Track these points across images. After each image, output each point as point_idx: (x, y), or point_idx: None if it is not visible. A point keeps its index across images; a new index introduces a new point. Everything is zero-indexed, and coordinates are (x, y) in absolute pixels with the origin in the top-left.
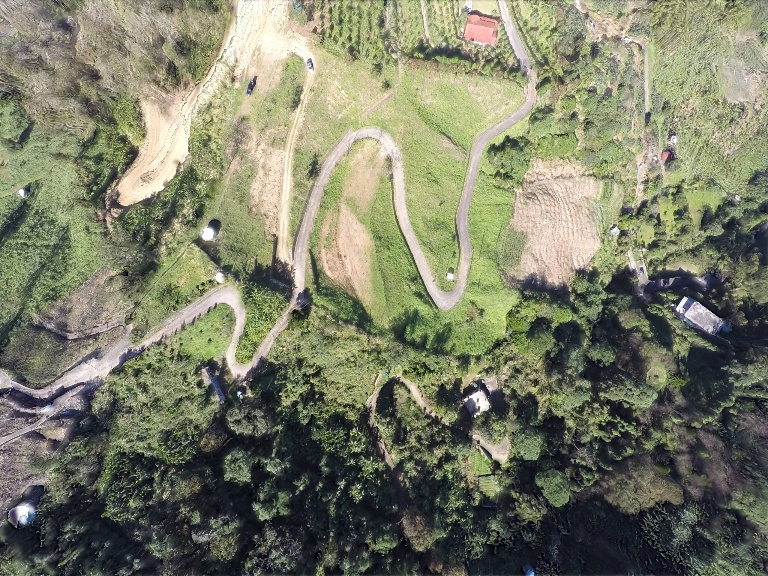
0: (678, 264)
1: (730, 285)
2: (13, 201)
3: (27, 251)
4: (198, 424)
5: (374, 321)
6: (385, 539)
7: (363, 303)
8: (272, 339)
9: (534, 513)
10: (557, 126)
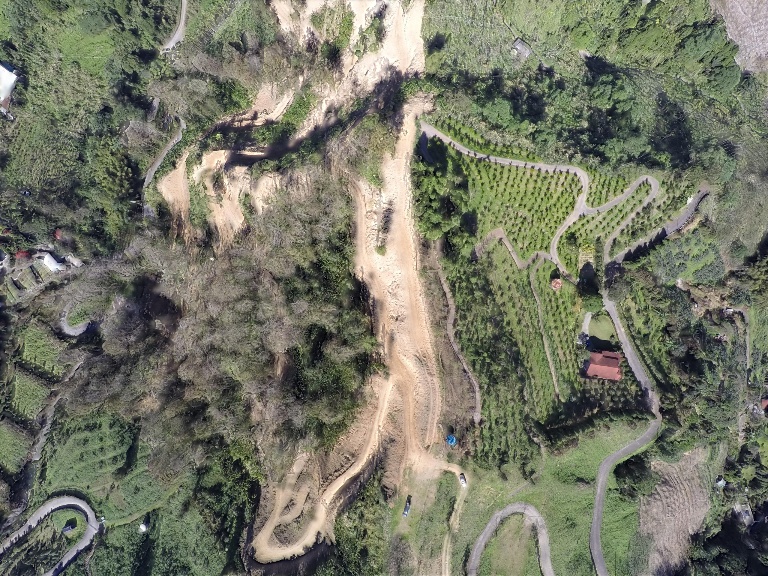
0: None
1: None
2: (134, 534)
3: None
4: None
5: None
6: None
7: None
8: None
9: None
10: None
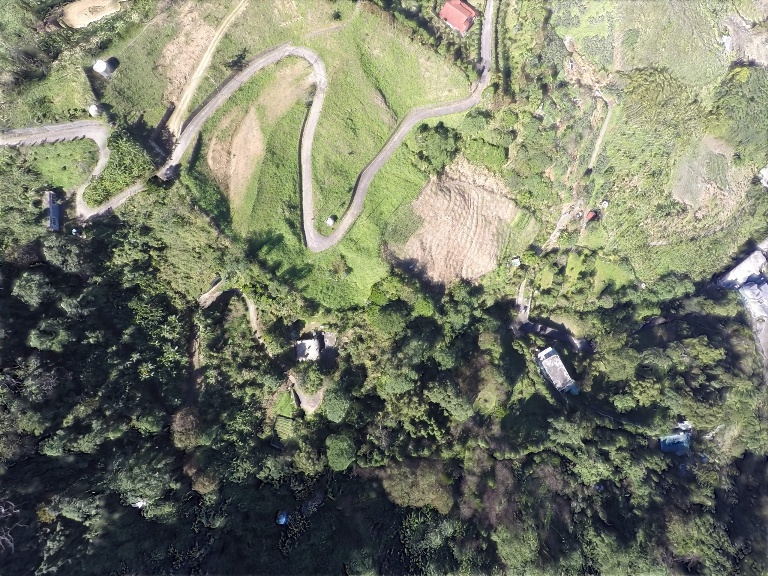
0: (561, 318)
1: (598, 357)
2: None
3: None
4: (18, 238)
5: (233, 224)
6: (148, 420)
7: (231, 204)
8: (127, 196)
9: (308, 465)
10: (492, 135)
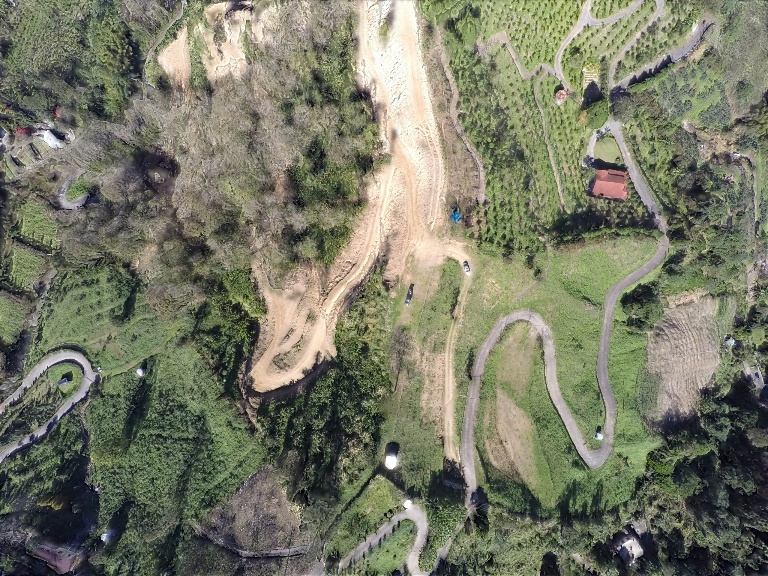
0: None
1: None
2: (131, 380)
3: (165, 445)
4: None
5: (542, 505)
6: None
7: (529, 487)
8: (450, 541)
9: None
10: None
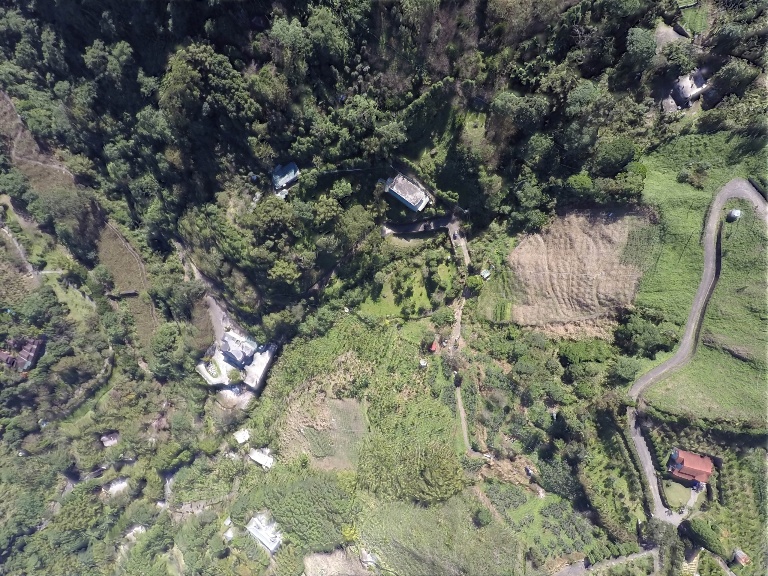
0: (415, 244)
1: None
2: None
3: None
4: None
5: None
6: None
7: None
8: None
9: None
10: None
